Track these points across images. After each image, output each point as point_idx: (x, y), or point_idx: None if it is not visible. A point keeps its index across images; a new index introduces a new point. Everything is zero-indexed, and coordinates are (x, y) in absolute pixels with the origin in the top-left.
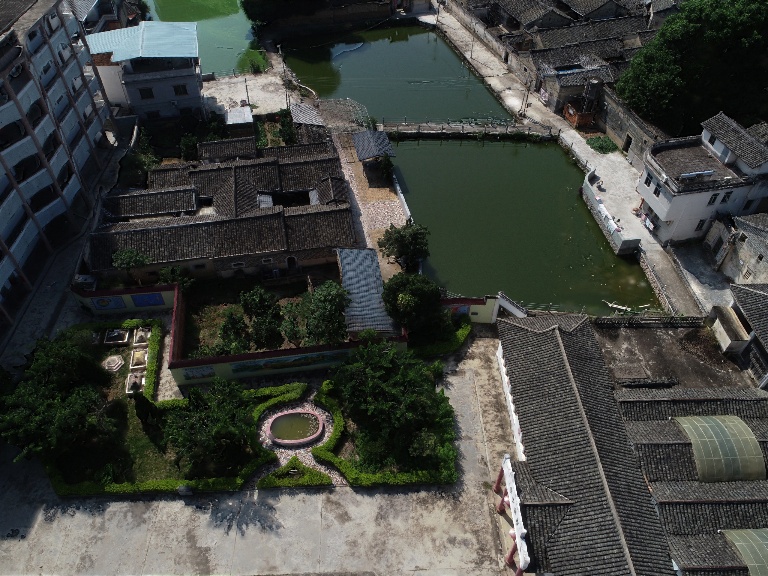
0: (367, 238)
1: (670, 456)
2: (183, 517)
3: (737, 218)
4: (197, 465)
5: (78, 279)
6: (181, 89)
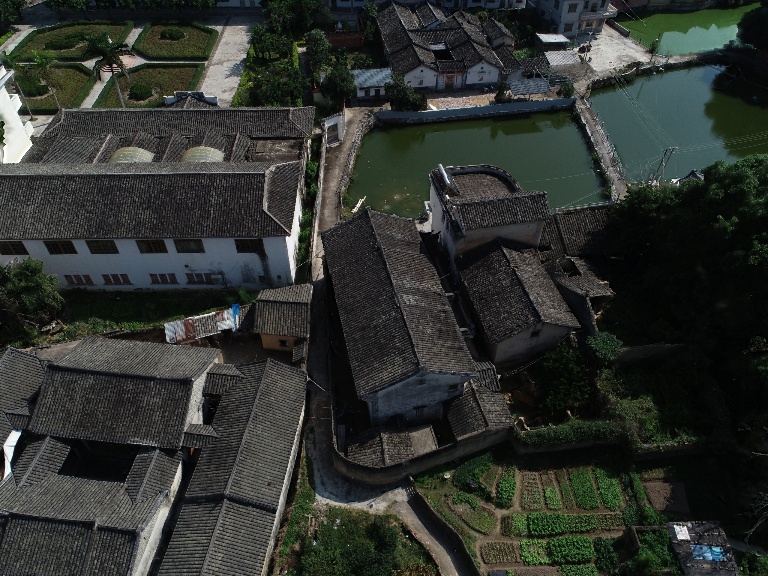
0: (428, 100)
1: None
2: (238, 58)
3: (409, 218)
4: None
5: None
6: (557, 4)
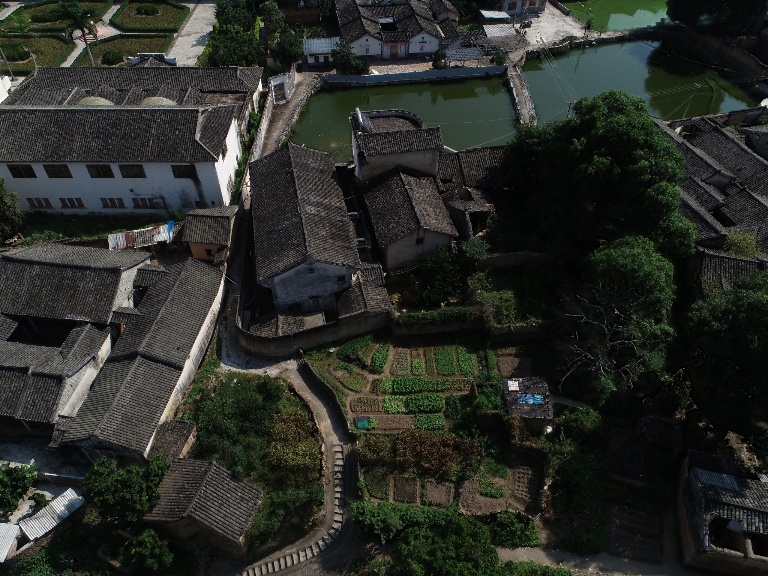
0: (373, 67)
1: None
2: None
3: None
4: None
5: None
6: None
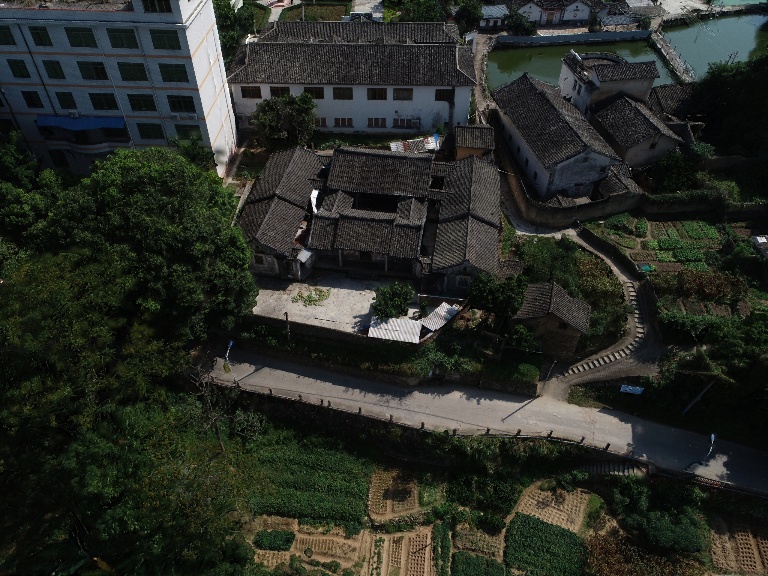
0: None
1: None
2: (376, 1)
3: None
4: None
5: None
6: None
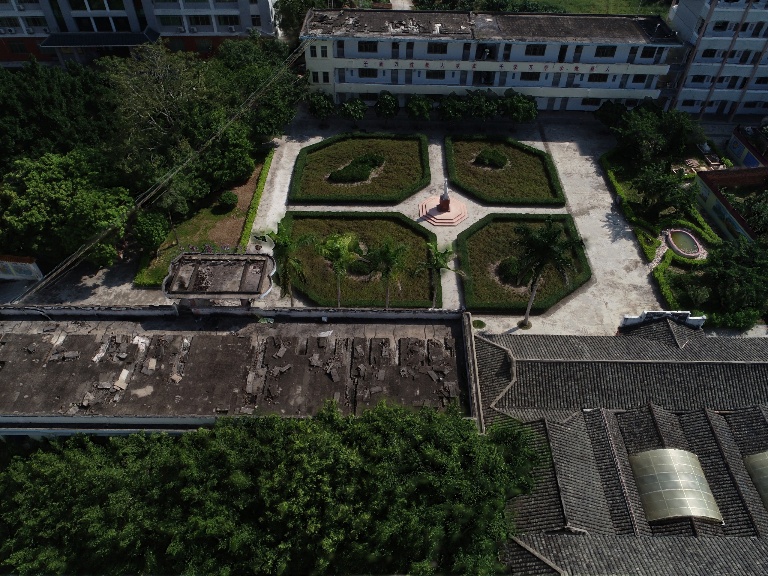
0: None
1: (759, 435)
2: (604, 203)
3: None
4: (637, 204)
5: (747, 128)
6: None
